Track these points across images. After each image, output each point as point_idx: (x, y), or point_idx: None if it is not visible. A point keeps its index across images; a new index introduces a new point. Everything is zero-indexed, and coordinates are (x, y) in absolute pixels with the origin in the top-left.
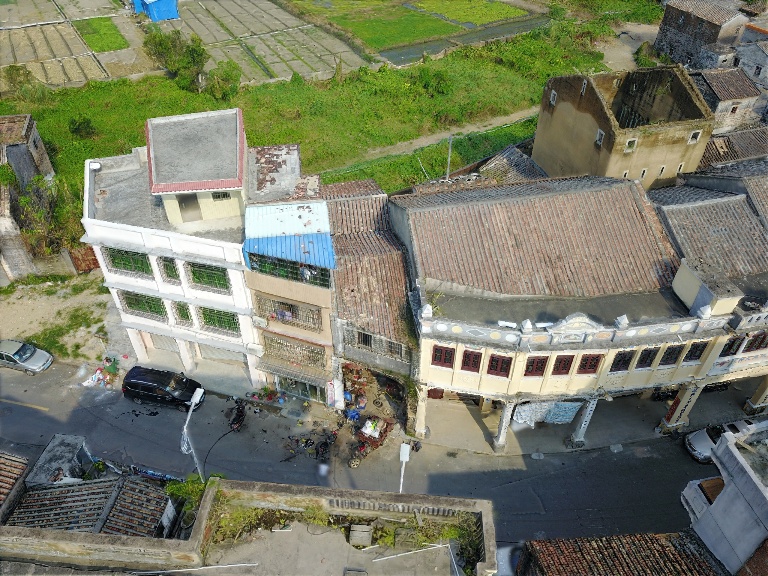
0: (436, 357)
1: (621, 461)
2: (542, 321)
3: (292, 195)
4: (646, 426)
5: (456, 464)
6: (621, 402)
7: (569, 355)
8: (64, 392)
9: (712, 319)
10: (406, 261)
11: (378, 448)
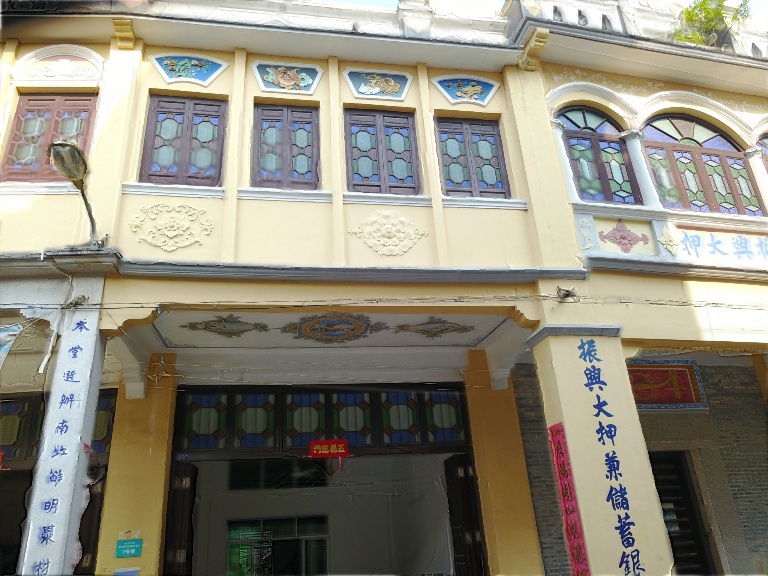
0: None
1: None
2: None
3: None
4: None
5: None
6: None
7: None
8: None
9: (439, 16)
10: None
11: None
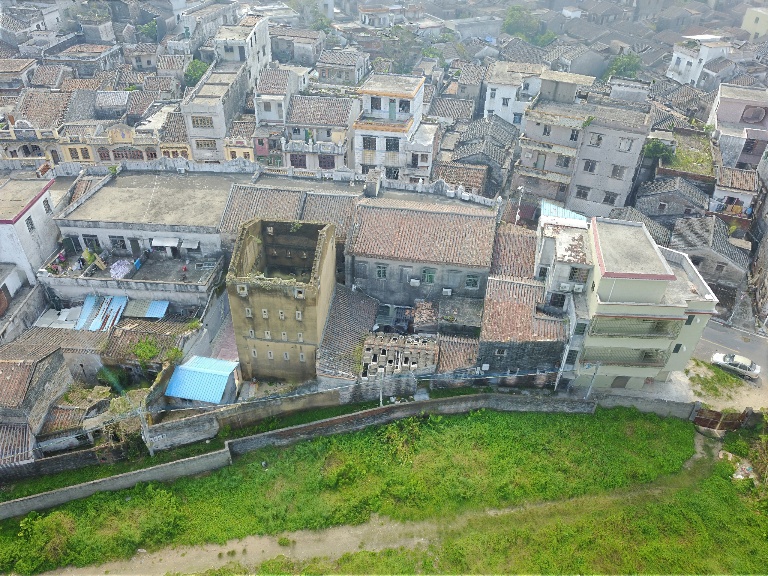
0: None
1: None
2: (445, 202)
3: (562, 229)
4: None
5: None
6: None
7: None
8: None
9: None
10: None
11: None
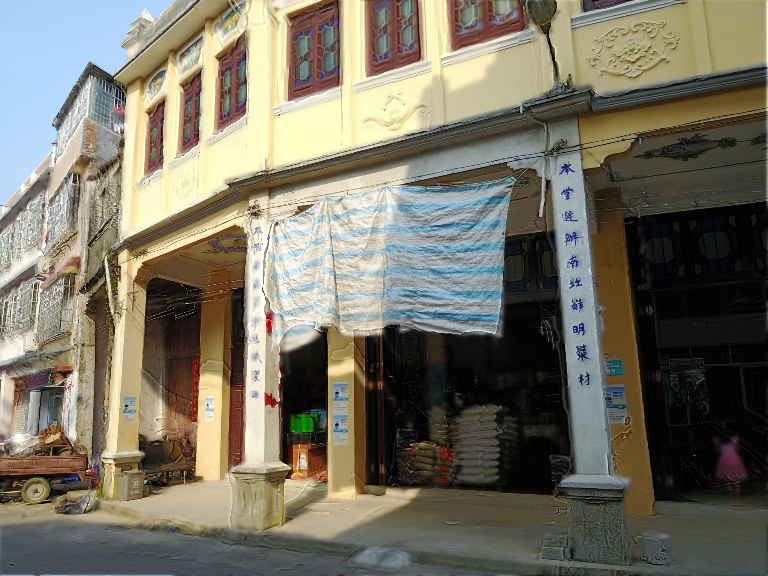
0: (151, 157)
1: None
2: None
3: None
4: None
5: (88, 534)
6: None
7: None
8: None
9: None
10: None
11: (7, 505)
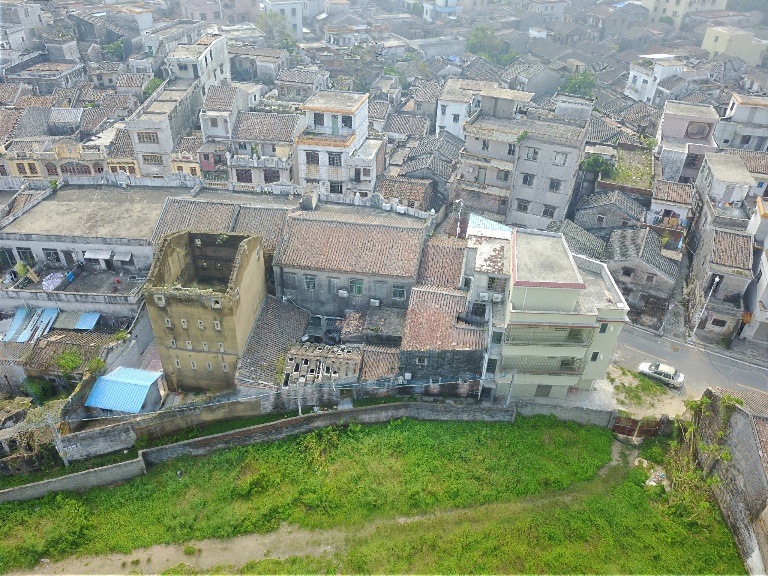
0: None
1: None
2: (380, 215)
3: (485, 240)
4: None
5: None
6: None
7: None
8: (620, 353)
9: None
10: (426, 241)
11: None
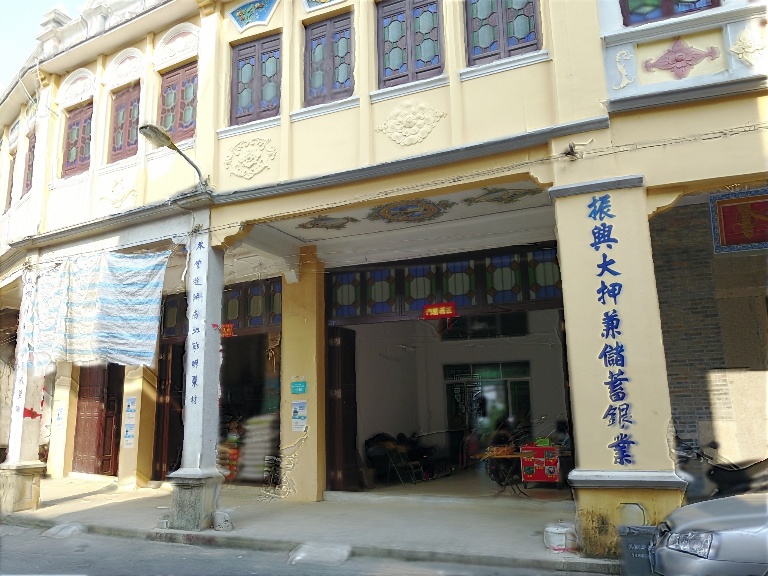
0: None
1: (267, 575)
2: None
3: None
4: (526, 540)
5: None
6: (505, 511)
7: (136, 89)
8: None
9: None
10: None
11: None
